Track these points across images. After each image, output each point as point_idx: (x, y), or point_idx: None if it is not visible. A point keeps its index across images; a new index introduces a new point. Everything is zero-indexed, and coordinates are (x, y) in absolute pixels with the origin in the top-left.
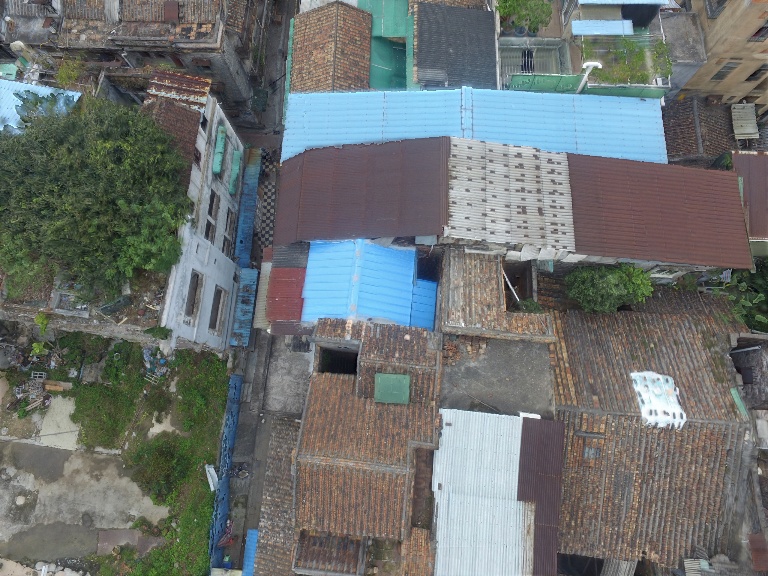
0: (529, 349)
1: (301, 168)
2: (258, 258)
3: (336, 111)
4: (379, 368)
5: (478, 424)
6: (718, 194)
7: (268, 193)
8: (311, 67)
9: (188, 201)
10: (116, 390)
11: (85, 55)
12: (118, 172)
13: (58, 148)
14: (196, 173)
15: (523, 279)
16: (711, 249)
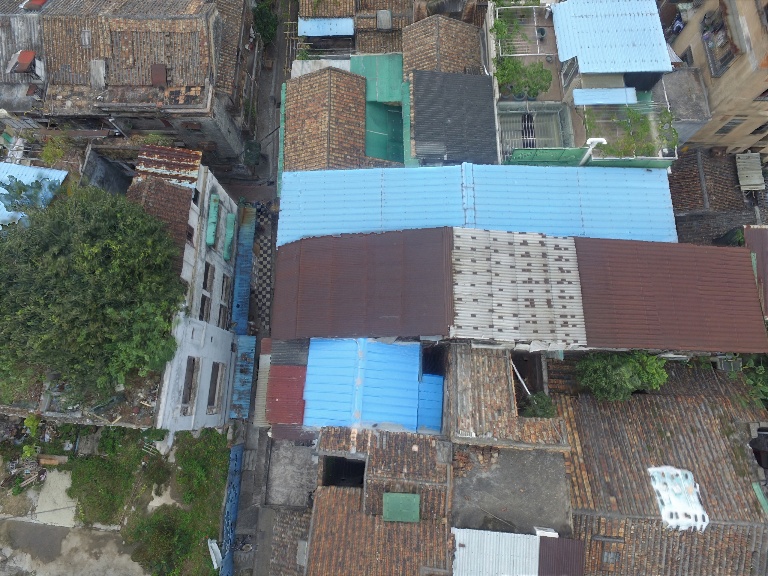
0: (543, 456)
1: (298, 258)
2: (256, 317)
3: (332, 190)
4: (387, 485)
5: (493, 544)
6: (731, 273)
7: (264, 247)
8: (305, 137)
9: (181, 289)
10: (113, 462)
11: (71, 120)
12: (107, 276)
13: (43, 256)
14: (189, 251)
15: (532, 364)
16: (727, 334)
